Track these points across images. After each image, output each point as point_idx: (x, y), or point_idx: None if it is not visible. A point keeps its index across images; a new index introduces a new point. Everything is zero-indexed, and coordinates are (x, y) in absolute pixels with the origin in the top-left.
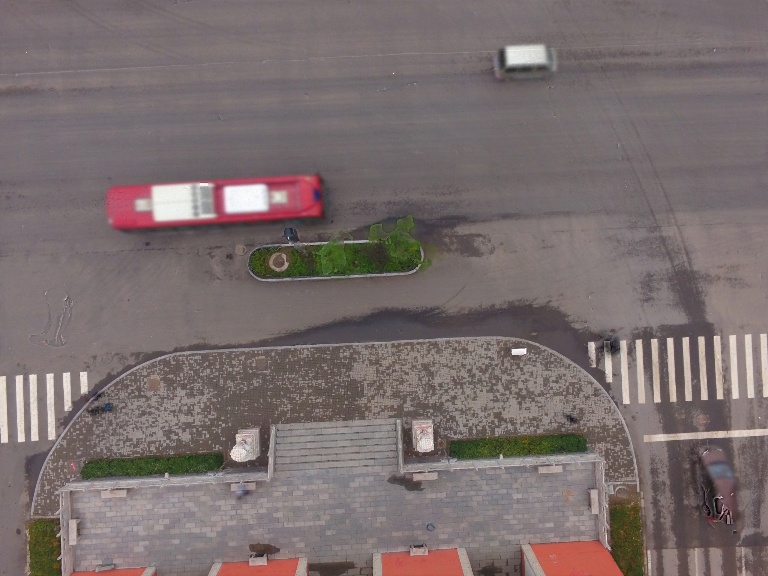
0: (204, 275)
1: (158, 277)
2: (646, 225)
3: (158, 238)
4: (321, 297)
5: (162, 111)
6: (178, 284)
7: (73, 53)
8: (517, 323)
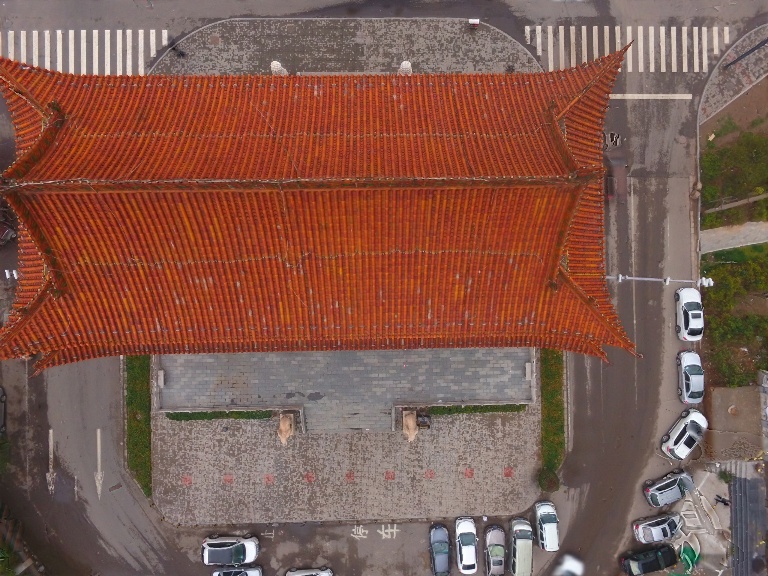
0: None
1: None
2: None
3: None
4: None
5: None
6: None
7: None
8: (474, 10)
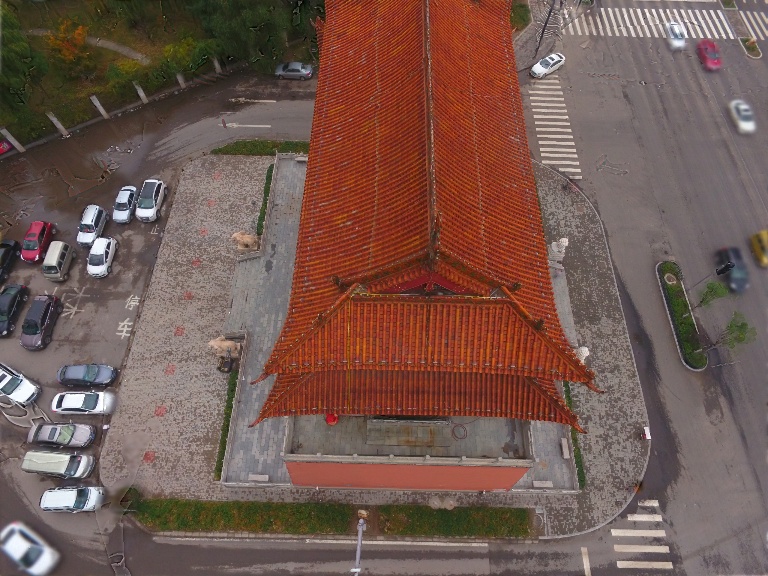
0: (651, 238)
1: (645, 215)
2: None
3: (668, 217)
4: (652, 303)
5: (746, 224)
6: (643, 225)
7: (764, 184)
8: (661, 440)
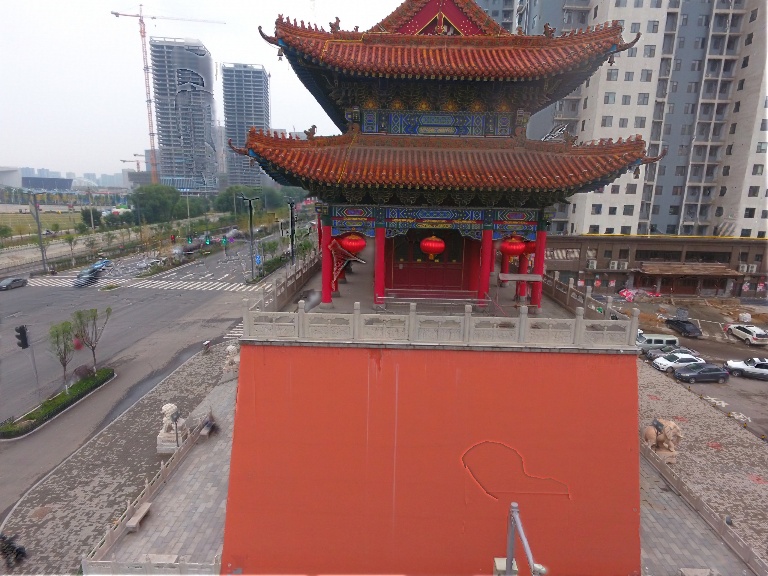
0: None
1: None
2: (174, 325)
3: None
4: (85, 410)
5: None
6: None
7: None
8: None
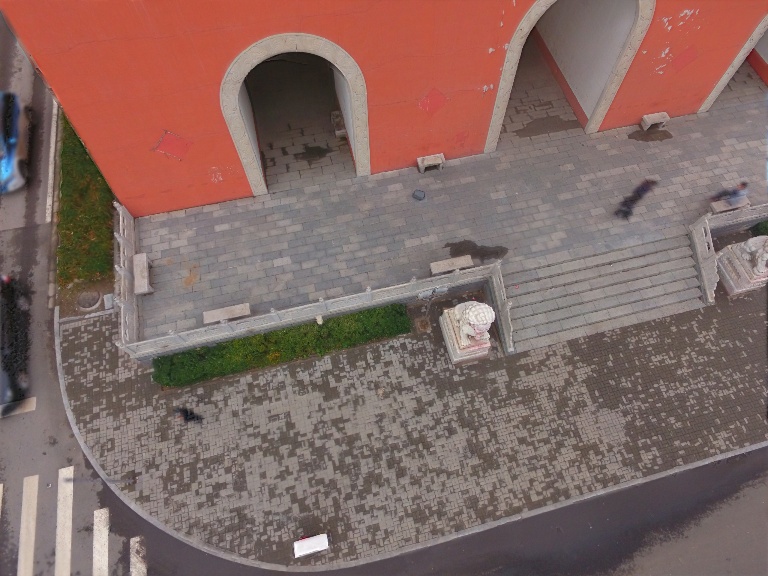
0: None
1: None
2: None
3: None
4: (749, 573)
5: None
6: None
7: None
8: None
